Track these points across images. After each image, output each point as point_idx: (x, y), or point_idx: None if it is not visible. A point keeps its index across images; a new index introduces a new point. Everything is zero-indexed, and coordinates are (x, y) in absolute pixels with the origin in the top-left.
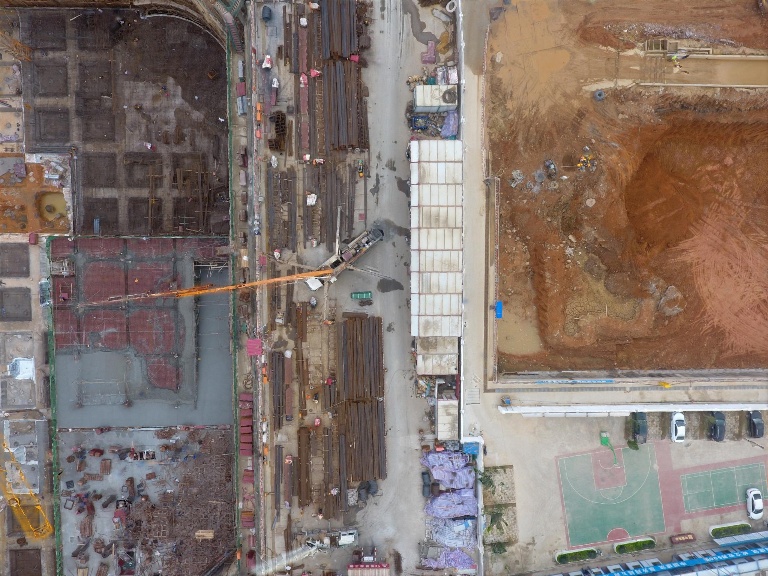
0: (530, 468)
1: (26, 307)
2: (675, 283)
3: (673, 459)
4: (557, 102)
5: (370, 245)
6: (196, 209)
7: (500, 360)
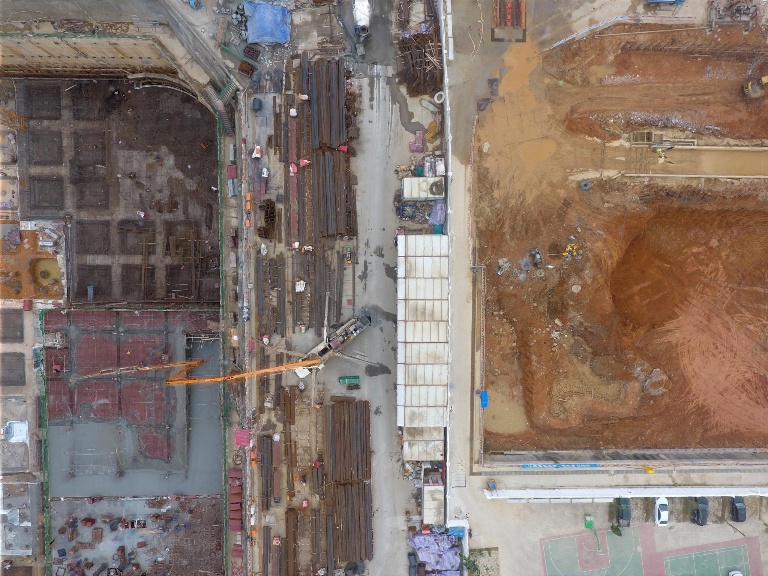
0: (515, 550)
1: (20, 371)
2: (660, 363)
3: (656, 541)
4: (543, 191)
5: (358, 333)
6: (189, 276)
7: (486, 440)
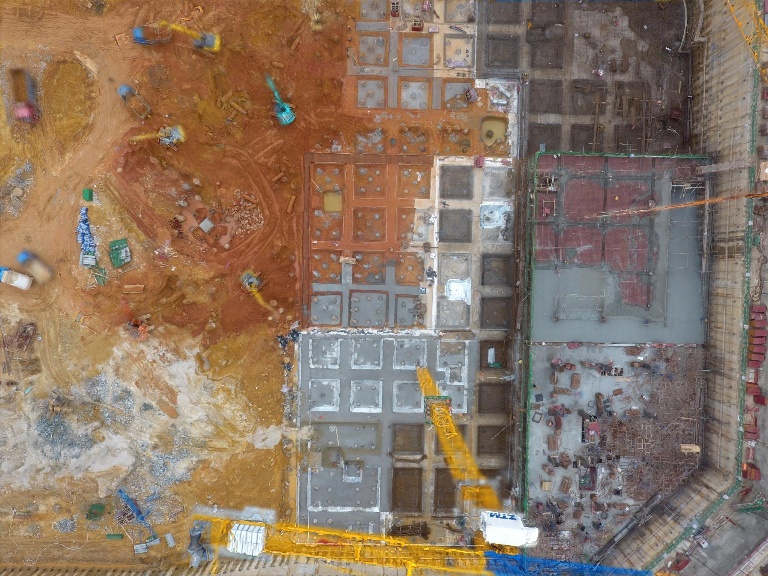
0: None
1: (464, 229)
2: None
3: None
4: None
5: None
6: (639, 136)
7: None
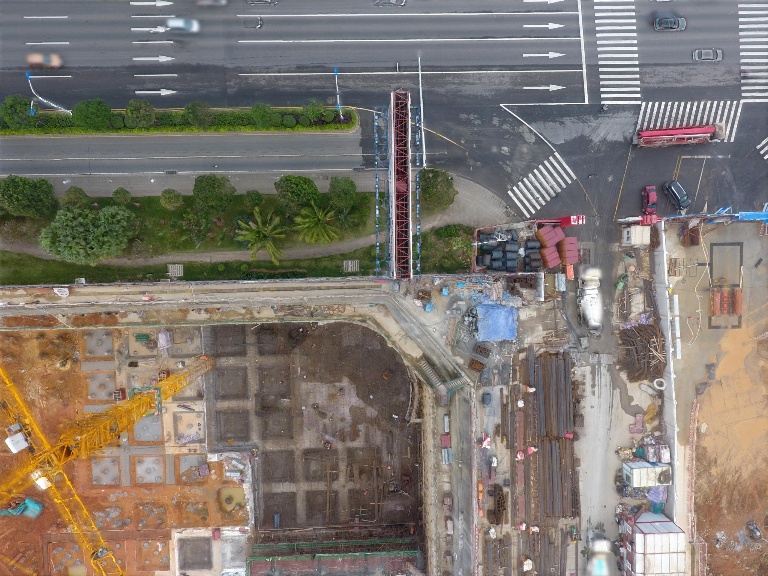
0: None
1: None
2: None
3: None
4: (759, 467)
5: None
6: (371, 501)
7: None
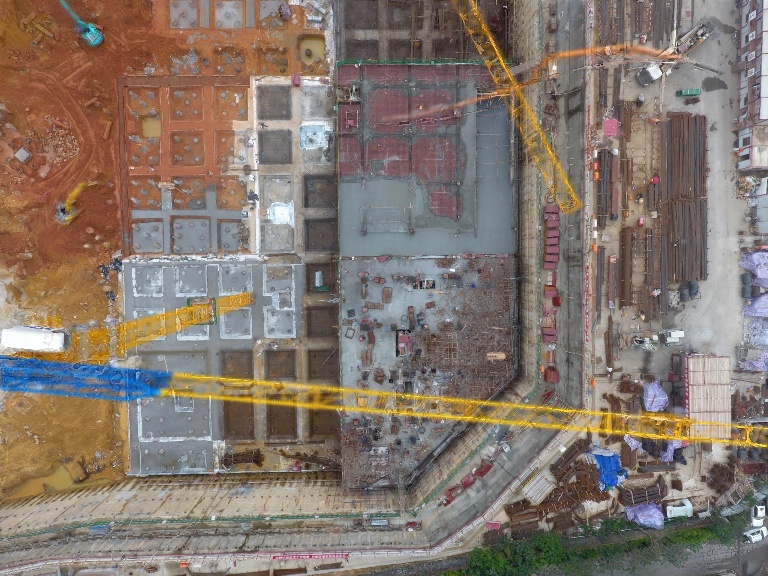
0: None
1: (285, 151)
2: None
3: None
4: None
5: (707, 36)
6: (457, 50)
7: None
